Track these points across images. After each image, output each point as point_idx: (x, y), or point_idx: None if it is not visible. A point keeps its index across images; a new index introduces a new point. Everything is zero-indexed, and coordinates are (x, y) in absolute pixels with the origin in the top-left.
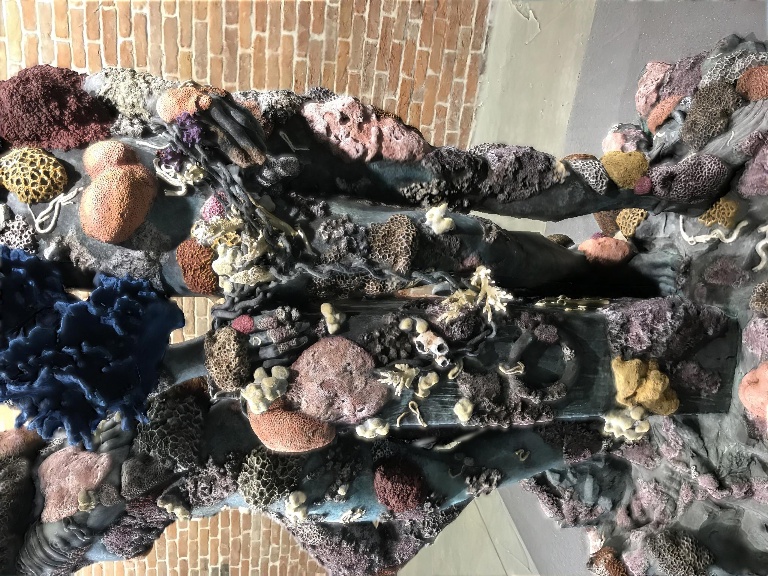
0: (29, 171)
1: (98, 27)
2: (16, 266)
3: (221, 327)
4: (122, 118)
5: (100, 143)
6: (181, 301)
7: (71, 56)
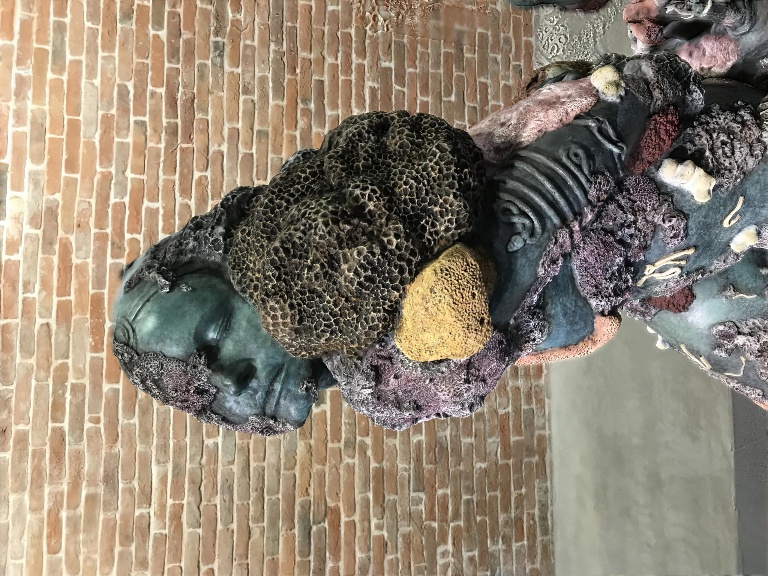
0: None
1: (175, 164)
2: None
3: None
4: None
5: None
6: (248, 475)
7: (144, 193)
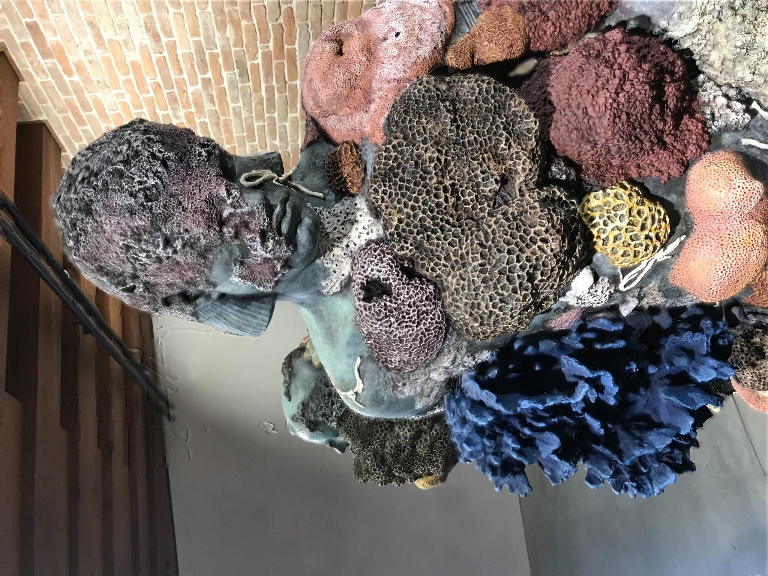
0: (643, 242)
1: None
2: (618, 353)
3: (763, 333)
4: (703, 81)
5: (717, 171)
6: None
7: None
